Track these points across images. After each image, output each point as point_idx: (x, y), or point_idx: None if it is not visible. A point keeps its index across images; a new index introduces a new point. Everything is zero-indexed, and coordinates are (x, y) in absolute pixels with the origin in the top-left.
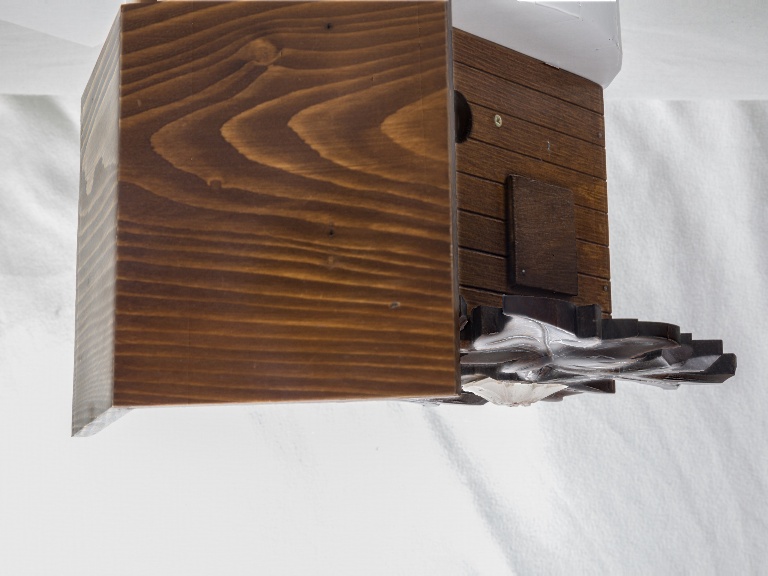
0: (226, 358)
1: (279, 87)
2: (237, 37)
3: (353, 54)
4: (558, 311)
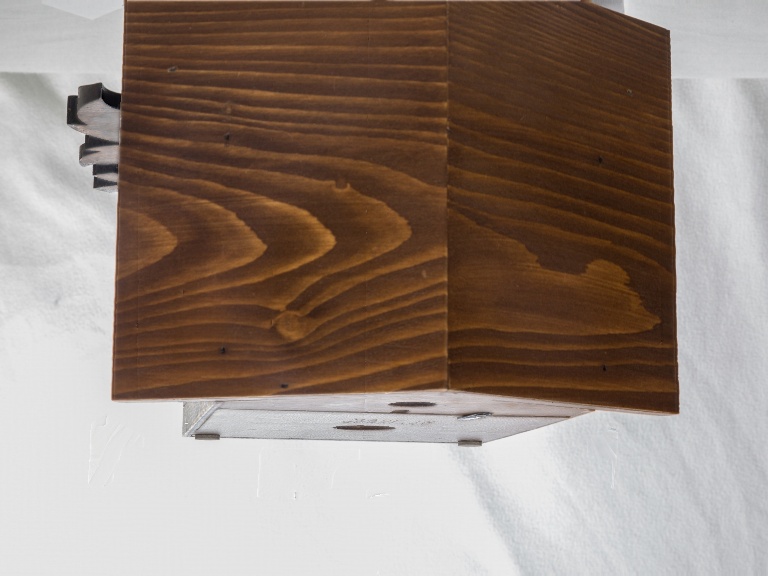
0: (331, 9)
1: (275, 287)
2: (317, 344)
3: (201, 319)
4: None
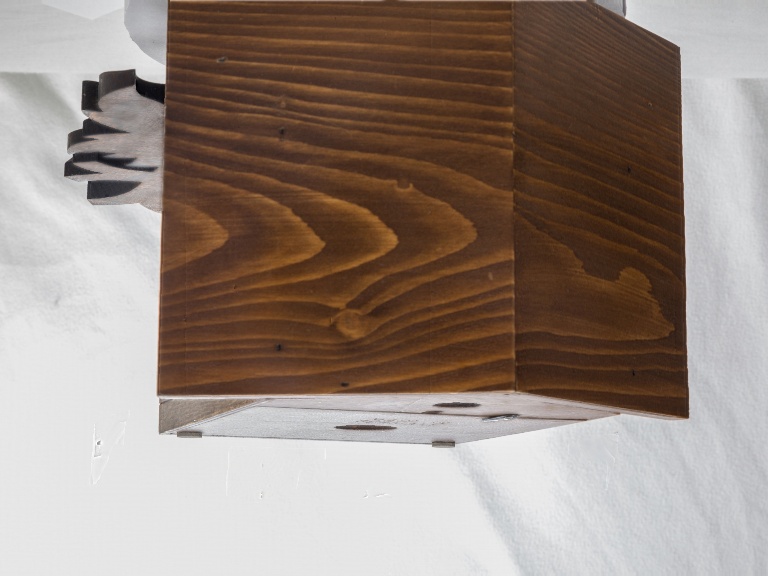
0: (392, 9)
1: (334, 284)
2: (380, 343)
3: (254, 315)
4: (101, 88)
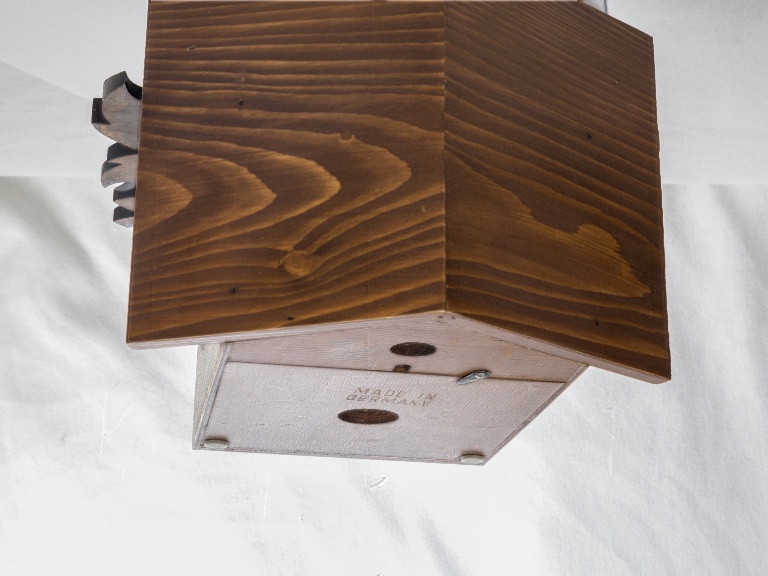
0: None
1: (283, 230)
2: (323, 278)
3: (213, 264)
4: None
